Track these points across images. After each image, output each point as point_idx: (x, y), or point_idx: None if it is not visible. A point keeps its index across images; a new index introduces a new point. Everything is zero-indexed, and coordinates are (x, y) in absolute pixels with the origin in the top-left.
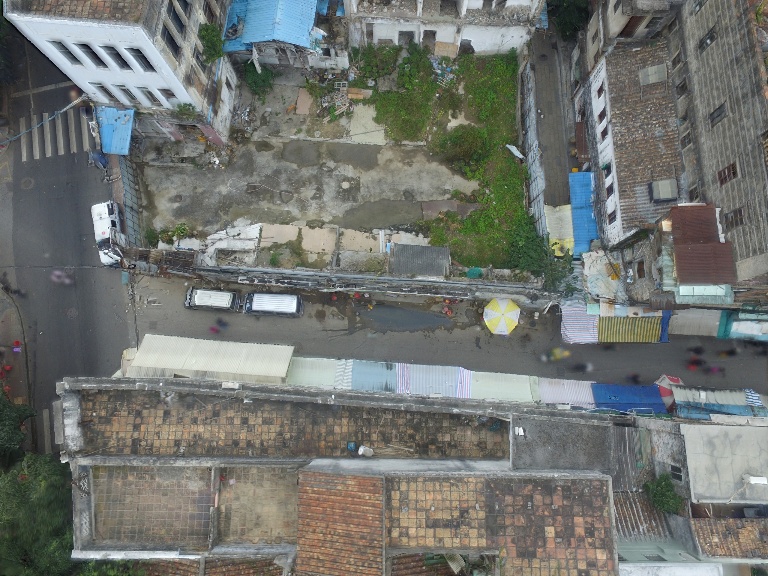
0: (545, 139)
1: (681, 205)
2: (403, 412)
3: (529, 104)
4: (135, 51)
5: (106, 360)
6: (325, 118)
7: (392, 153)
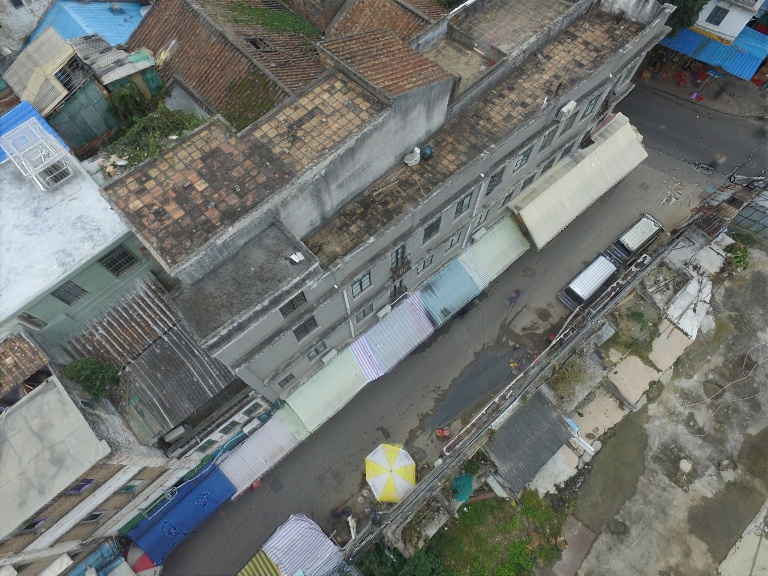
0: None
1: None
2: None
3: None
4: None
5: None
6: None
7: (698, 568)
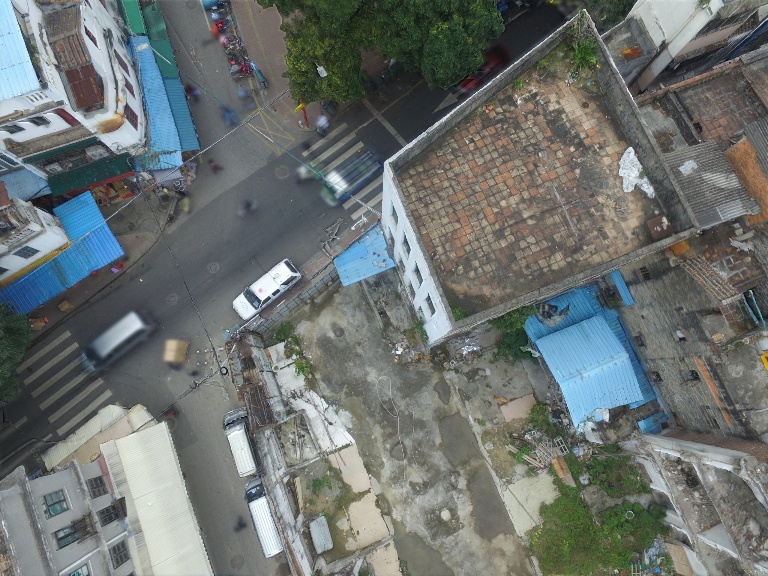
0: None
1: None
2: None
3: None
4: None
5: (140, 362)
6: (512, 446)
7: (513, 551)
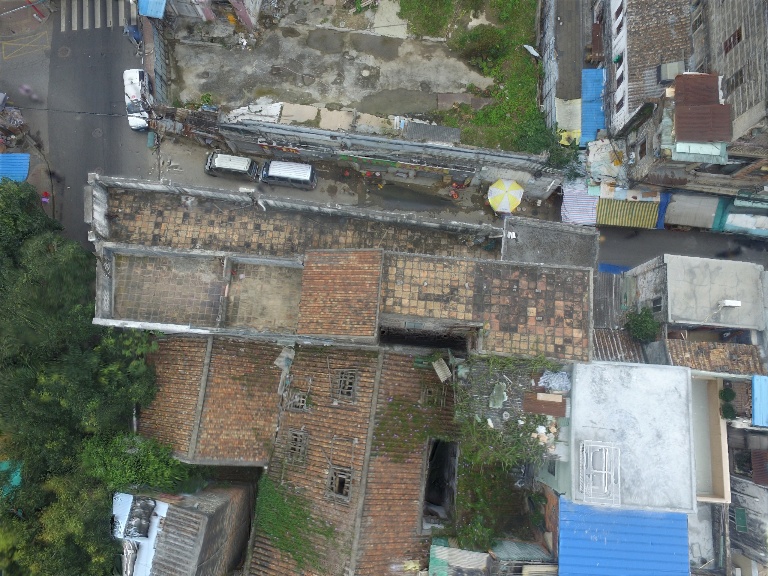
0: (562, 45)
1: (686, 73)
2: (405, 229)
3: (549, 5)
4: None
5: None
6: (351, 9)
7: (413, 47)
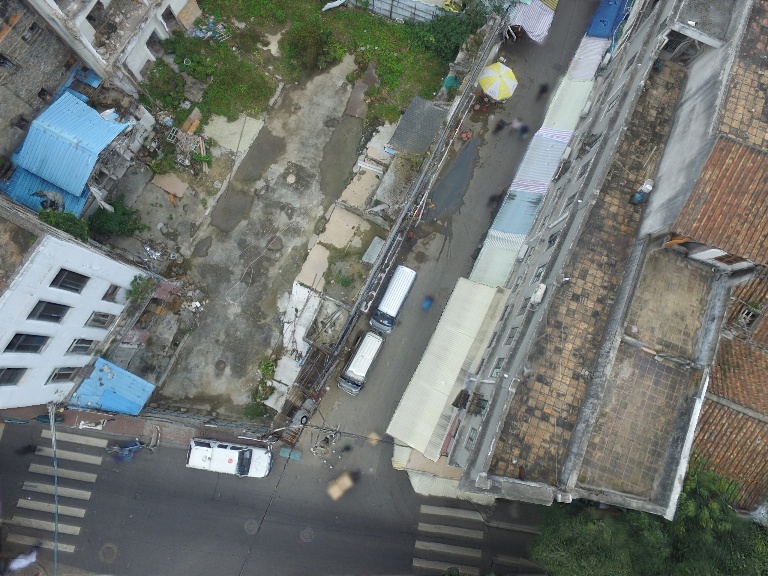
0: None
1: None
2: None
3: None
4: (58, 278)
5: (379, 508)
6: (203, 168)
7: (277, 119)
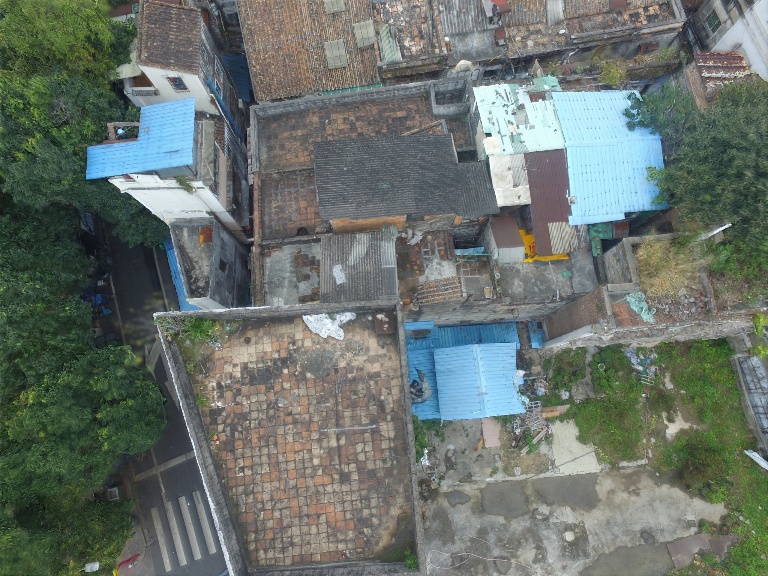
0: None
1: None
2: None
3: (766, 404)
4: None
5: None
6: (523, 450)
7: (611, 481)
